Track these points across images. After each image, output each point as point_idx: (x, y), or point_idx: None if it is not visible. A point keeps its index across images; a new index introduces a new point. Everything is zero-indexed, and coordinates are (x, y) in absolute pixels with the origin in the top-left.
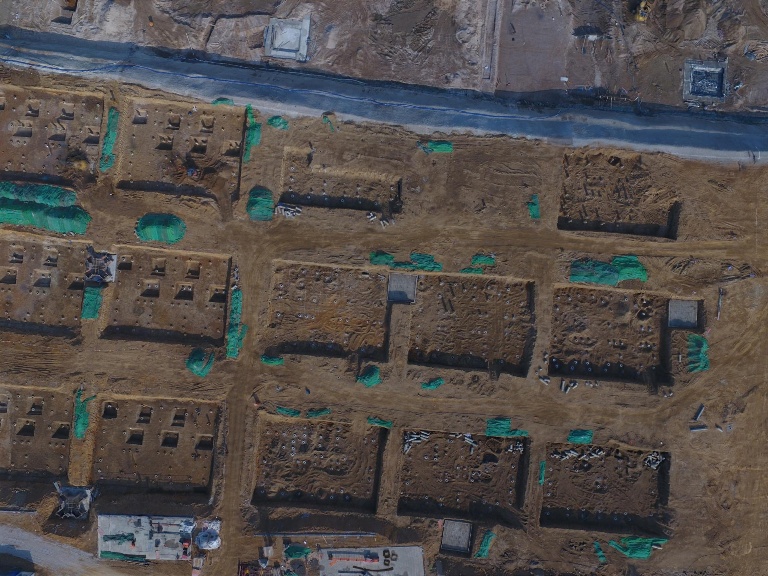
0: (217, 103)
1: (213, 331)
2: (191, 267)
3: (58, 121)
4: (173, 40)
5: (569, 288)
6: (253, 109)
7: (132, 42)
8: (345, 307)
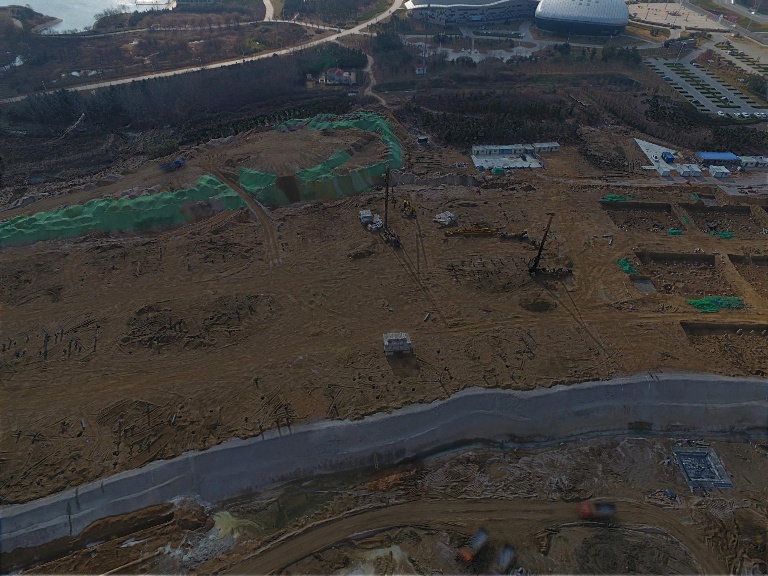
0: None
1: None
2: None
3: None
4: None
5: None
6: None
7: None
8: None
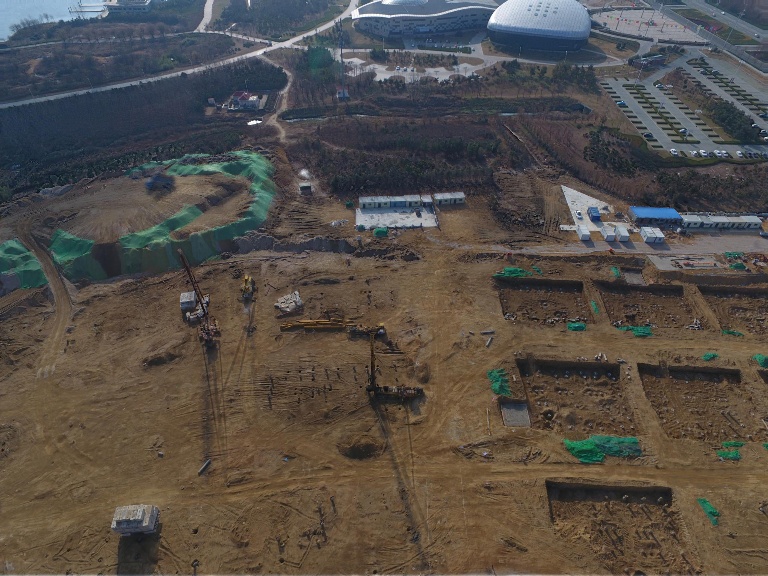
0: None
1: None
2: None
3: None
4: None
5: None
6: None
7: None
8: None
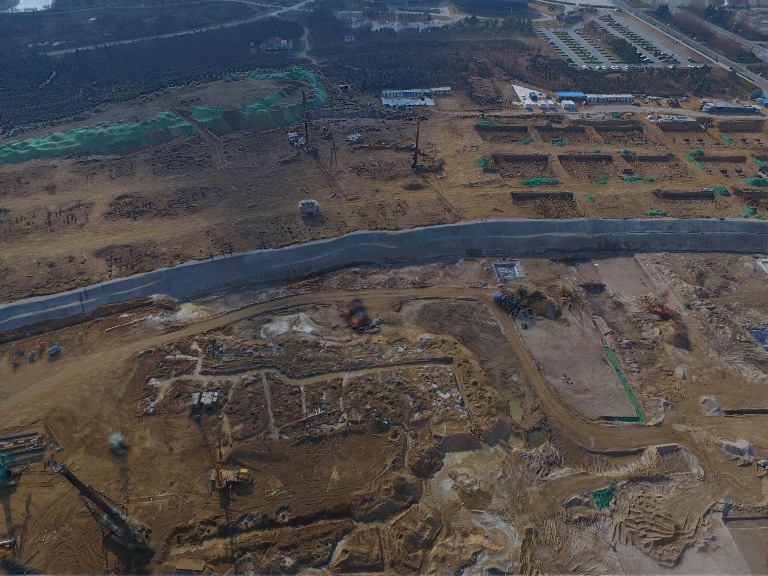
0: None
1: None
2: None
3: None
4: None
5: None
6: (761, 219)
7: None
8: None
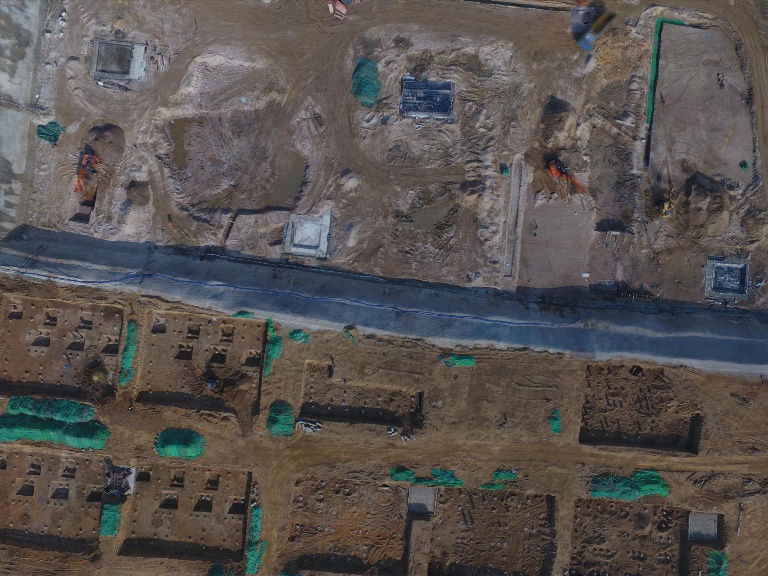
0: (238, 316)
1: (232, 543)
2: (210, 476)
3: (76, 330)
4: (192, 238)
5: (589, 499)
6: (274, 322)
7: (151, 241)
8: (365, 519)
